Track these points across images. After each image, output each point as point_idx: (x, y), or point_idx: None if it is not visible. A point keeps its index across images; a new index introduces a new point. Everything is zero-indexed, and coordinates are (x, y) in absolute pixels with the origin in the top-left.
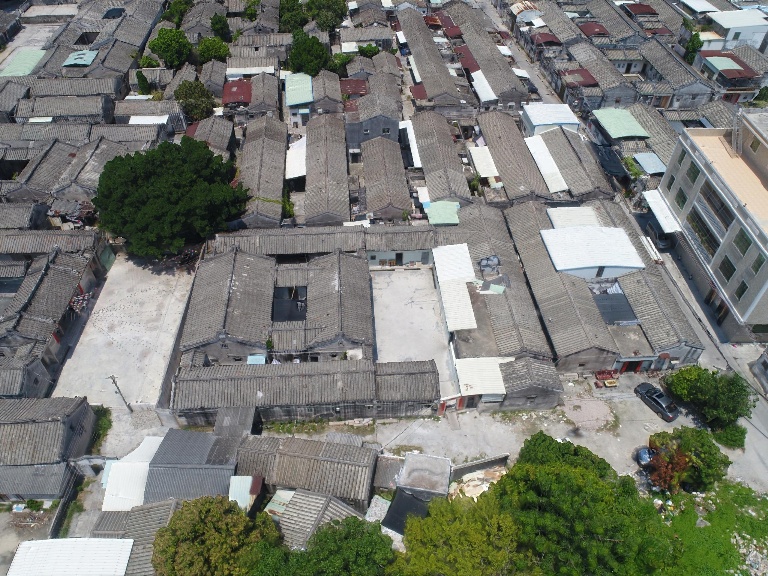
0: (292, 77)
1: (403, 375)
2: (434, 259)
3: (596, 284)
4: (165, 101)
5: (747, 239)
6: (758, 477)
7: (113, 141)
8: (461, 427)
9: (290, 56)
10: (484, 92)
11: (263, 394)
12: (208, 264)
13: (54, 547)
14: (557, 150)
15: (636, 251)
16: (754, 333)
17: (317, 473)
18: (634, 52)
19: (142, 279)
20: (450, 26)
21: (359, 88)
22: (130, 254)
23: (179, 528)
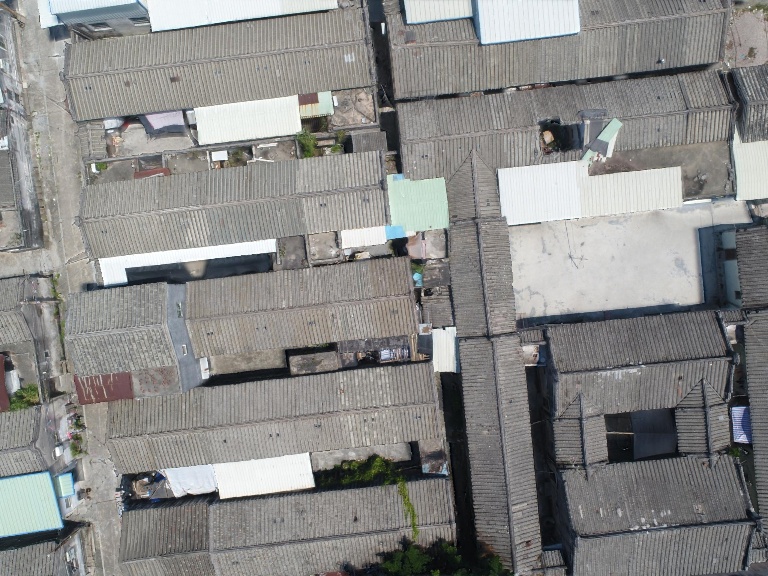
0: None
1: None
2: None
3: None
4: None
5: None
6: None
7: None
8: None
9: None
10: None
11: None
12: (583, 573)
13: None
14: None
15: None
16: None
17: None
18: None
19: None
20: None
21: None
22: None
23: None
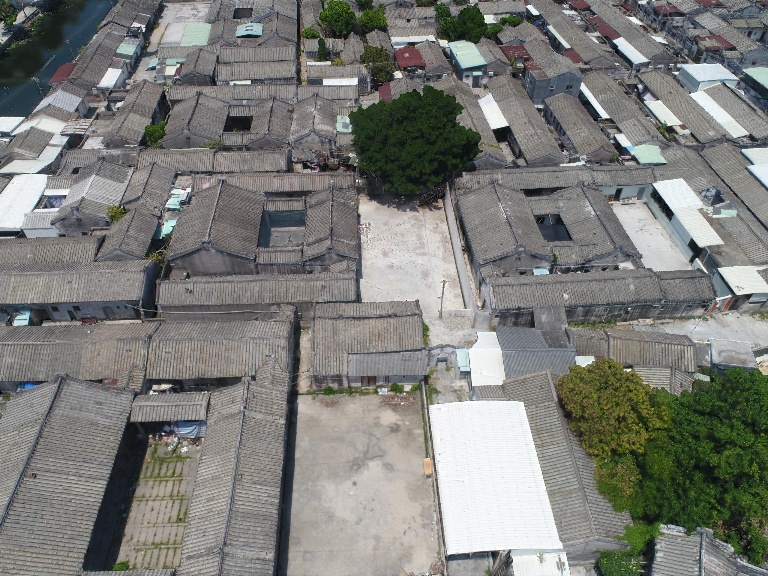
0: (455, 44)
1: (682, 279)
2: (658, 191)
3: None
4: (353, 65)
5: None
6: None
7: (325, 98)
8: (729, 325)
9: (451, 25)
10: (634, 56)
11: (569, 296)
12: (468, 196)
13: (462, 407)
14: (726, 102)
15: None
16: None
17: (649, 352)
18: (755, 21)
19: (392, 215)
20: (574, 0)
21: (522, 53)
22: (370, 195)
23: (591, 380)
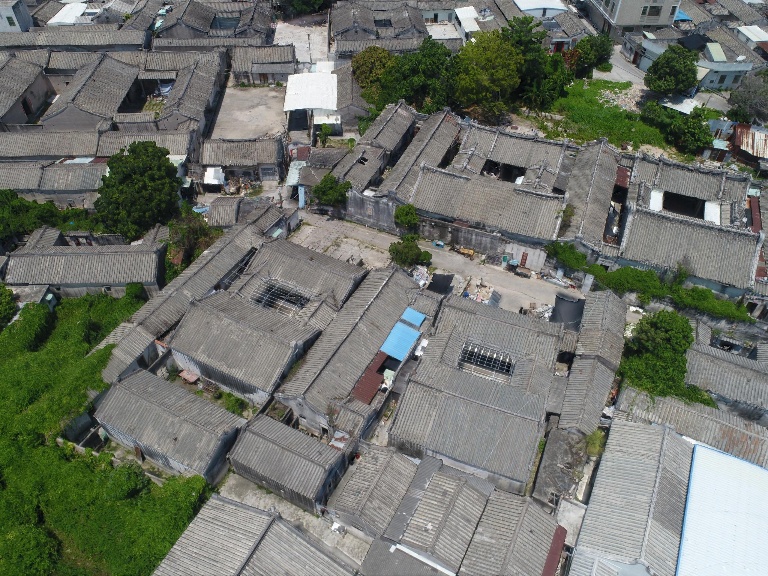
0: None
1: (446, 40)
2: (456, 12)
3: None
4: None
5: None
6: (615, 78)
7: None
8: None
9: None
10: None
11: None
12: (337, 10)
13: (305, 74)
14: None
15: (564, 5)
16: (623, 37)
17: None
18: None
19: (295, 29)
20: None
21: None
22: (285, 21)
23: (363, 52)
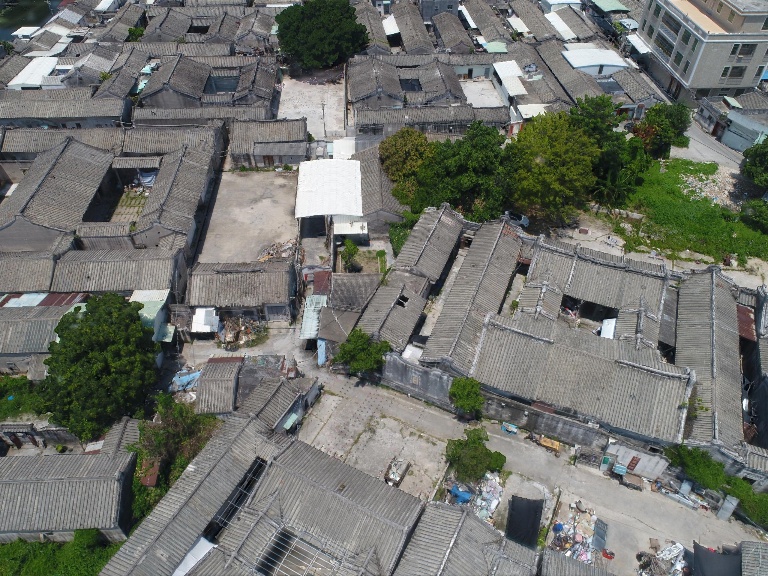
0: None
1: (488, 109)
2: (495, 68)
3: (598, 80)
4: None
5: (689, 34)
6: (696, 157)
7: (264, 14)
8: None
9: None
10: None
11: (408, 117)
12: (355, 67)
13: (320, 162)
14: (568, 18)
15: (623, 60)
16: (696, 100)
17: None
18: None
19: (305, 87)
20: None
21: None
22: (292, 76)
23: (394, 137)
